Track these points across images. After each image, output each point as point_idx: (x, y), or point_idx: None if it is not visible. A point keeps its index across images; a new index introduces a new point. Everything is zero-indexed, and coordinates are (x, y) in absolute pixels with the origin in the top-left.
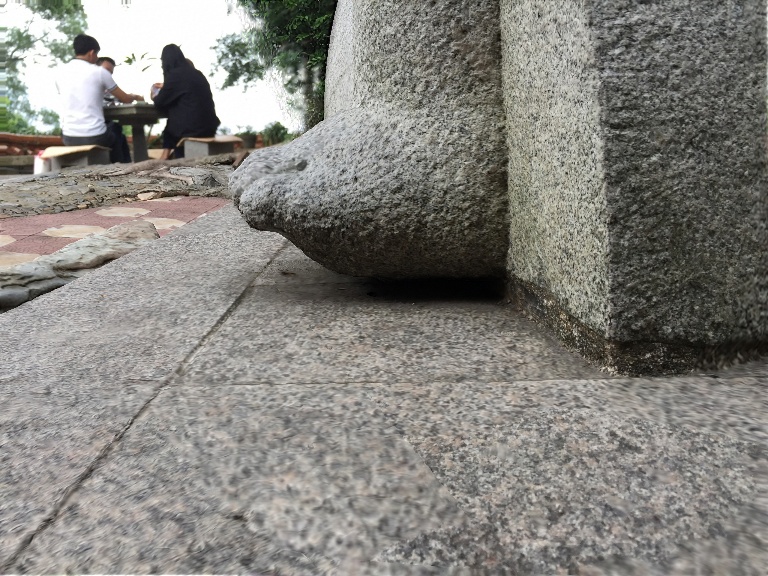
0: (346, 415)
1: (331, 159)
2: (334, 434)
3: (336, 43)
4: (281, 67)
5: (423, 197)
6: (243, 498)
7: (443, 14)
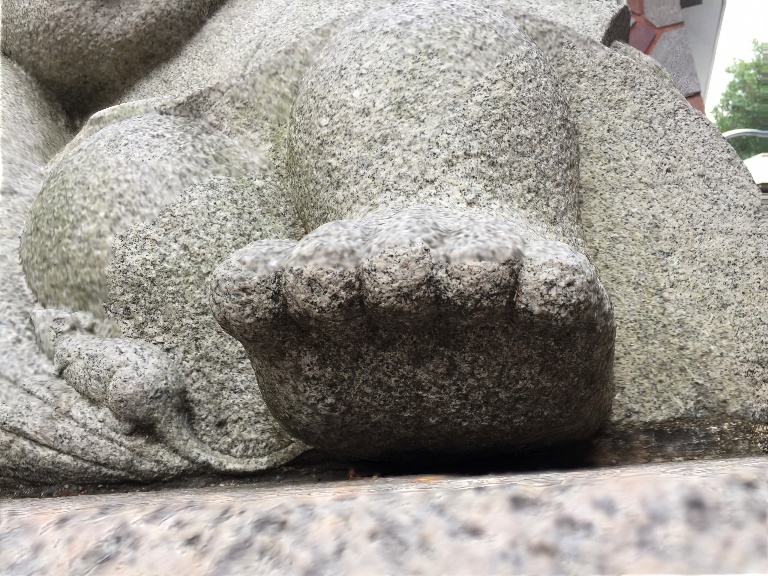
0: None
1: None
2: None
3: None
4: None
5: None
6: None
7: (565, 141)
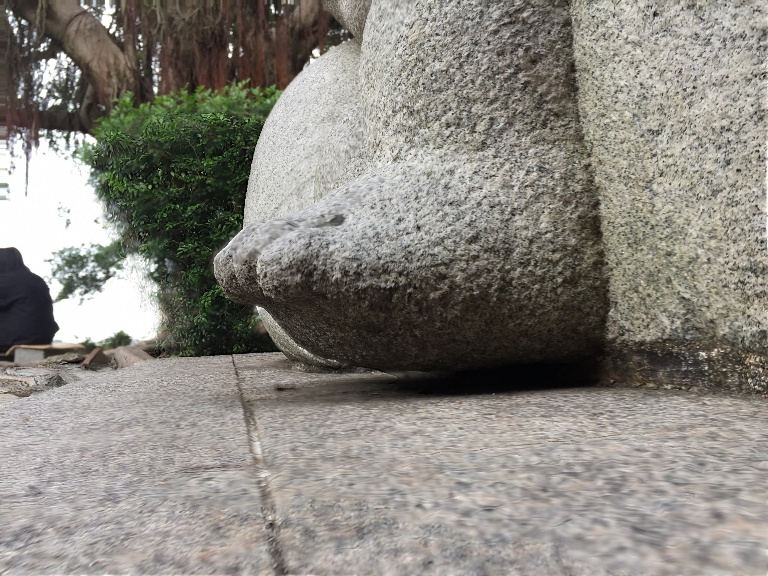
0: (656, 461)
1: (378, 209)
2: (693, 478)
3: (264, 181)
4: (148, 255)
5: (505, 248)
6: (750, 571)
7: (509, 42)
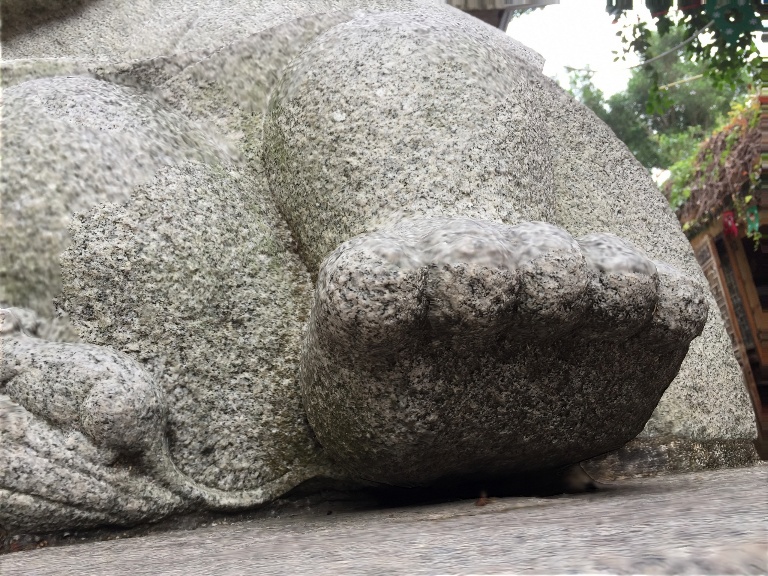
0: None
1: None
2: None
3: None
4: None
5: None
6: None
7: None
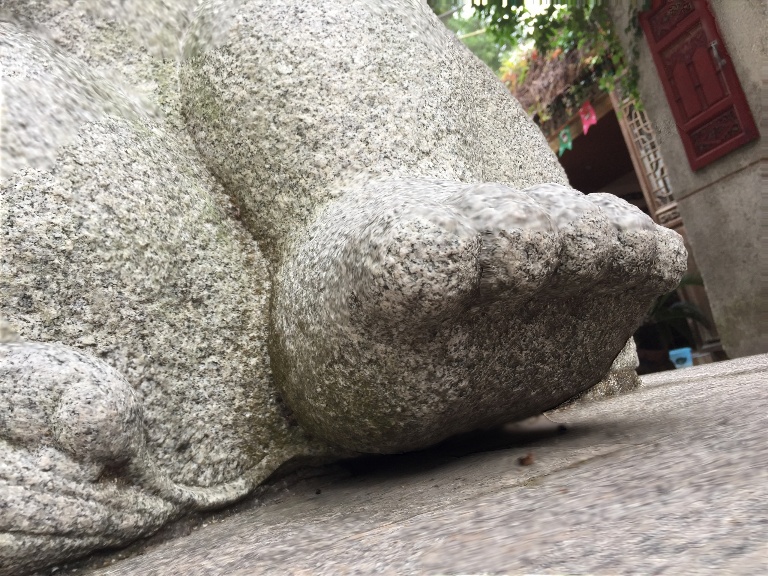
0: None
1: None
2: None
3: None
4: None
5: None
6: None
7: None
